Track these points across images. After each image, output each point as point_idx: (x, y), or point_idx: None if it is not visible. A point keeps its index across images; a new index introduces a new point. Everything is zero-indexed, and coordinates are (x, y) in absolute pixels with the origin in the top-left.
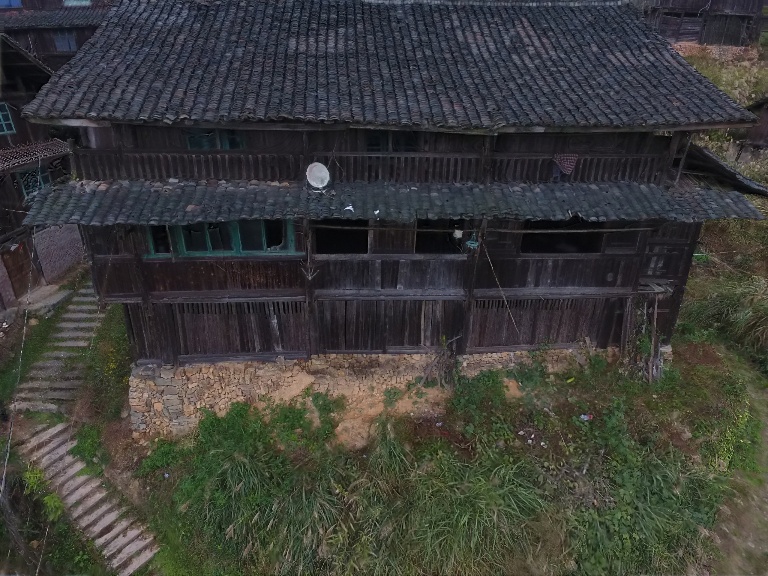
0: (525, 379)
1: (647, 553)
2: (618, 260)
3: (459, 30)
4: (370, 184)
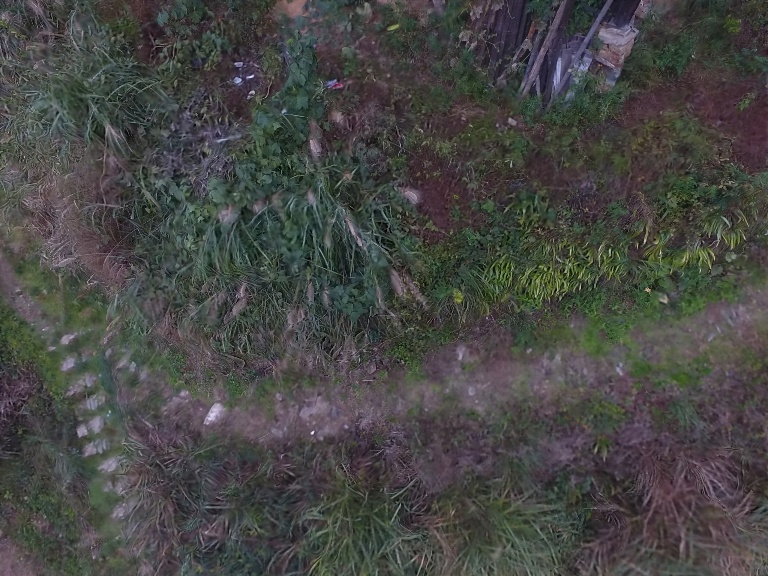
0: None
1: (235, 280)
2: None
3: None
4: None
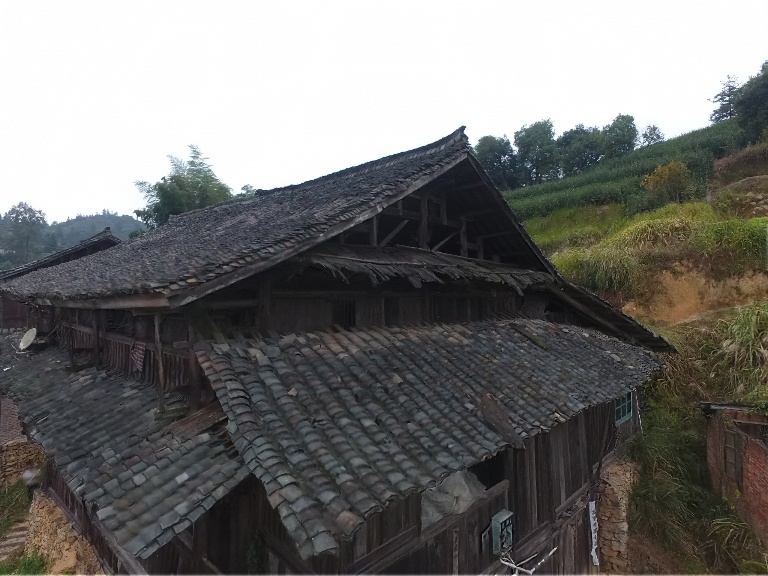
0: None
1: None
2: (178, 550)
3: (244, 214)
4: (59, 353)
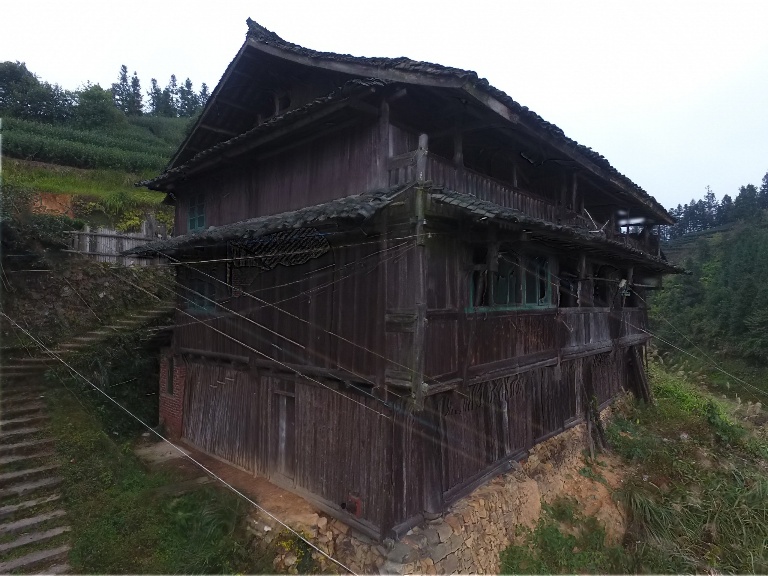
0: (628, 427)
1: None
2: None
3: None
4: None
